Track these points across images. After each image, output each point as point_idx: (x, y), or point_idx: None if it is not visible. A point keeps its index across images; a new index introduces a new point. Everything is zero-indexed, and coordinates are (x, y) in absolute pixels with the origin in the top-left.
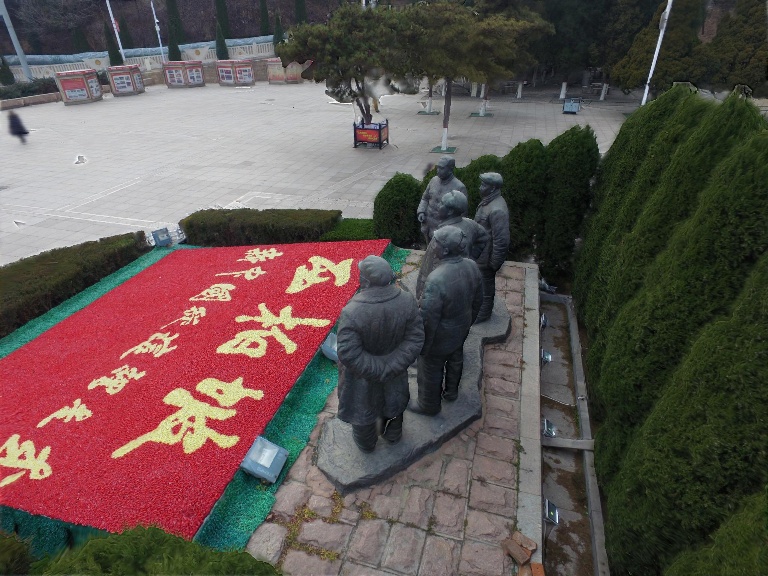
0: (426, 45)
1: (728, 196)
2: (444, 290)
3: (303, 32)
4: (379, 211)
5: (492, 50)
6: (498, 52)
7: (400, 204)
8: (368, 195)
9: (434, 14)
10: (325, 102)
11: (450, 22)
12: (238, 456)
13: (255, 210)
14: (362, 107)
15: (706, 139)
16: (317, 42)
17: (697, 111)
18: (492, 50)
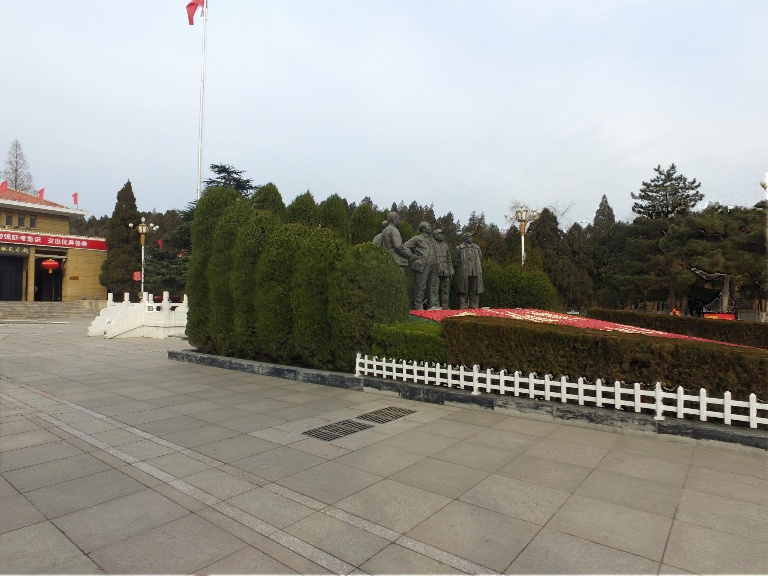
0: None
1: None
2: None
3: None
4: None
5: None
6: None
7: None
8: (107, 575)
9: None
10: None
11: None
12: (524, 309)
13: (653, 341)
14: None
15: None
16: None
17: None
18: None
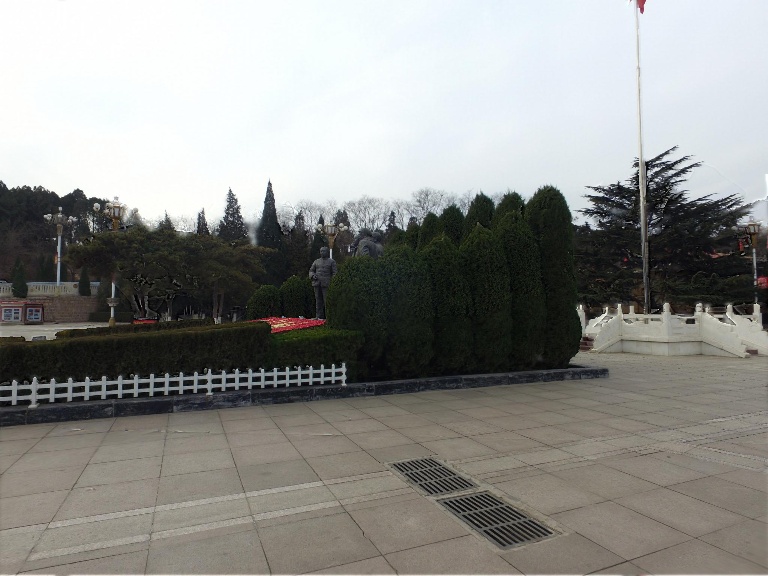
0: (200, 259)
1: (446, 222)
2: (381, 250)
3: (107, 236)
4: (257, 305)
5: (248, 265)
6: (254, 265)
7: (272, 299)
8: None
9: (204, 241)
10: (39, 329)
11: (217, 246)
12: None
13: None
14: (139, 303)
15: (428, 224)
16: (125, 242)
17: (416, 227)
18: (248, 265)
